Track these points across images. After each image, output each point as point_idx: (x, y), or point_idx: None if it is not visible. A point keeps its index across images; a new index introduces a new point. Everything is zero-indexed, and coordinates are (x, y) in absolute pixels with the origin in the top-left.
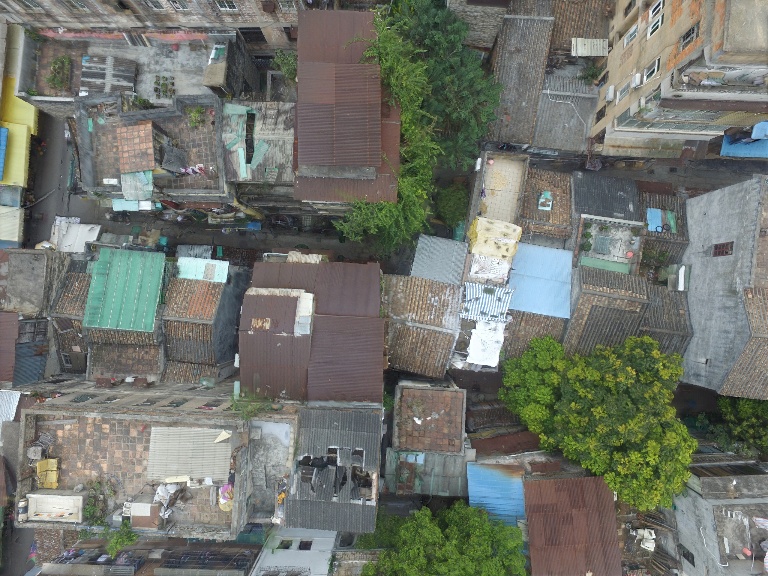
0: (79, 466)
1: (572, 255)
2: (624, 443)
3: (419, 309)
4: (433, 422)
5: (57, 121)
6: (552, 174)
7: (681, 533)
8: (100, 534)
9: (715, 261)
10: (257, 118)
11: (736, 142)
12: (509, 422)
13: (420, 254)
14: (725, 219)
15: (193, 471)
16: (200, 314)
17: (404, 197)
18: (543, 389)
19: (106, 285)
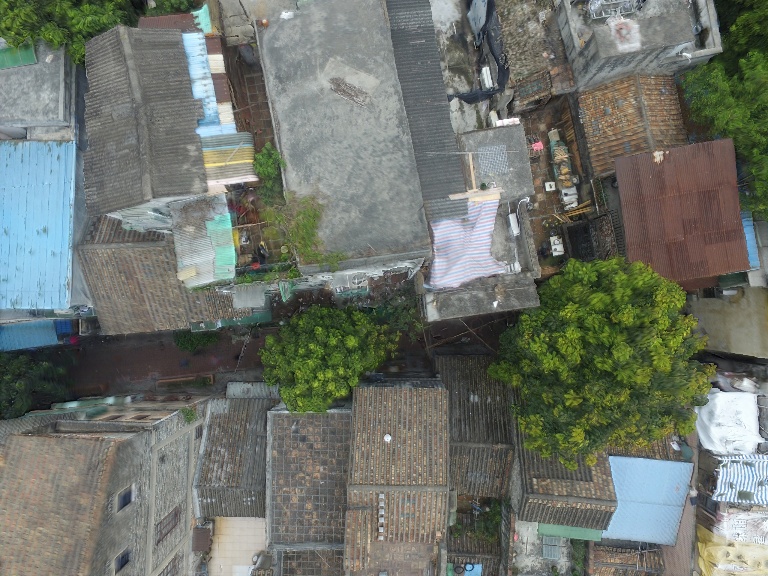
0: None
1: None
2: None
3: None
4: None
5: None
6: None
7: None
8: None
9: None
10: None
11: None
12: None
13: None
14: None
15: None
16: None
17: None
18: None
19: None
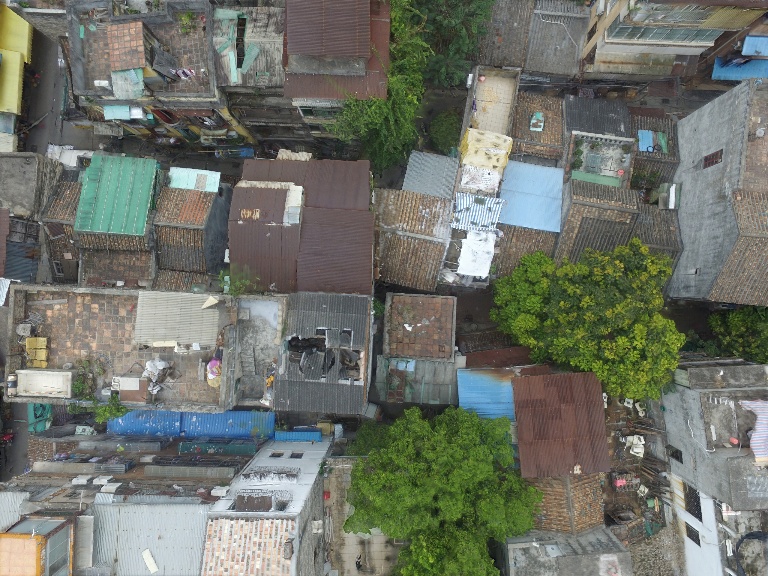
0: (68, 345)
1: (563, 172)
2: (612, 332)
3: (410, 220)
4: (423, 328)
5: (51, 54)
6: (544, 98)
7: (670, 433)
8: (89, 408)
9: (705, 172)
10: (248, 23)
11: (727, 64)
12: (501, 345)
13: (411, 169)
14: (715, 129)
15: (181, 337)
16: (191, 220)
17: (393, 92)
18: (533, 298)
19: (97, 190)
